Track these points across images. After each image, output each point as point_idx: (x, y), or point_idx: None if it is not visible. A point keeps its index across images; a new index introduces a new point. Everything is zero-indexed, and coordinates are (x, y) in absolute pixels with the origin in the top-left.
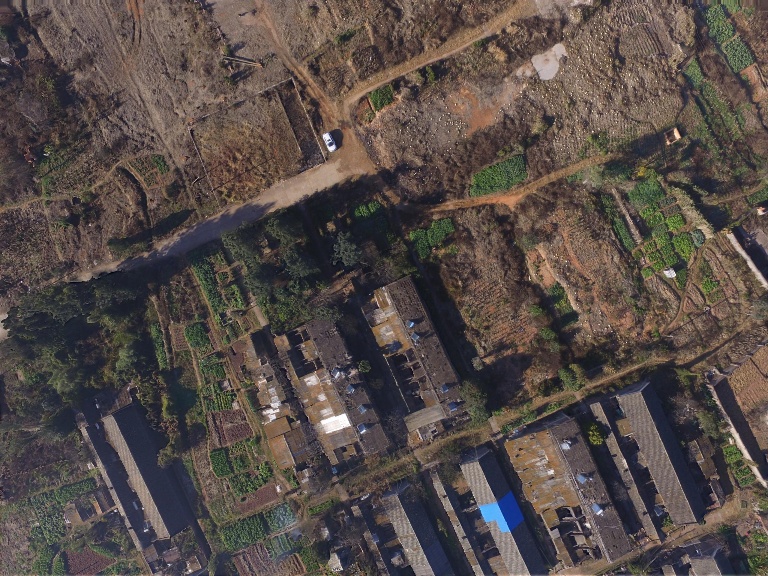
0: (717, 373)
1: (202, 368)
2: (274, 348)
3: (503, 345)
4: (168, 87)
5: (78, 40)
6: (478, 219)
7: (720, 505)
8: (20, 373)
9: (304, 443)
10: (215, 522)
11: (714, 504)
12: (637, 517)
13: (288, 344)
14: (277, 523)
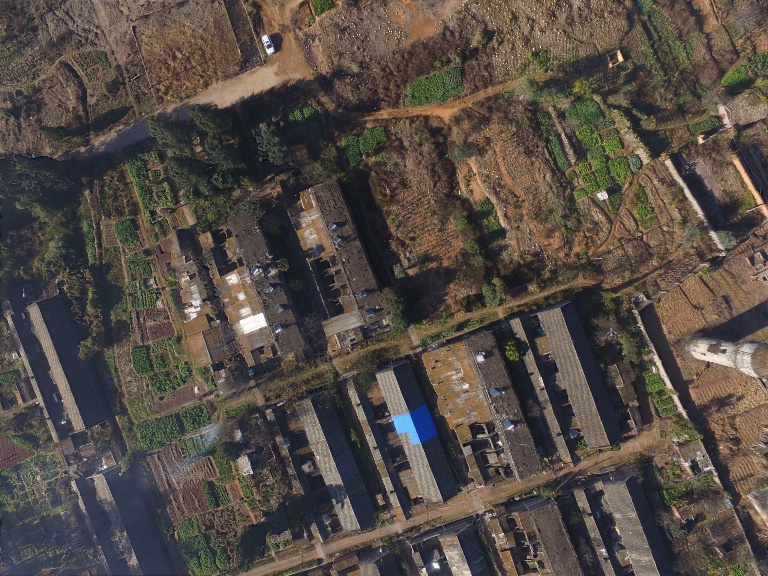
0: (644, 300)
1: (129, 264)
2: (200, 247)
3: (428, 257)
4: None
5: None
6: (411, 129)
7: (637, 432)
8: None
9: (222, 342)
10: (133, 420)
11: (631, 431)
12: (552, 440)
13: (212, 241)
14: (192, 423)
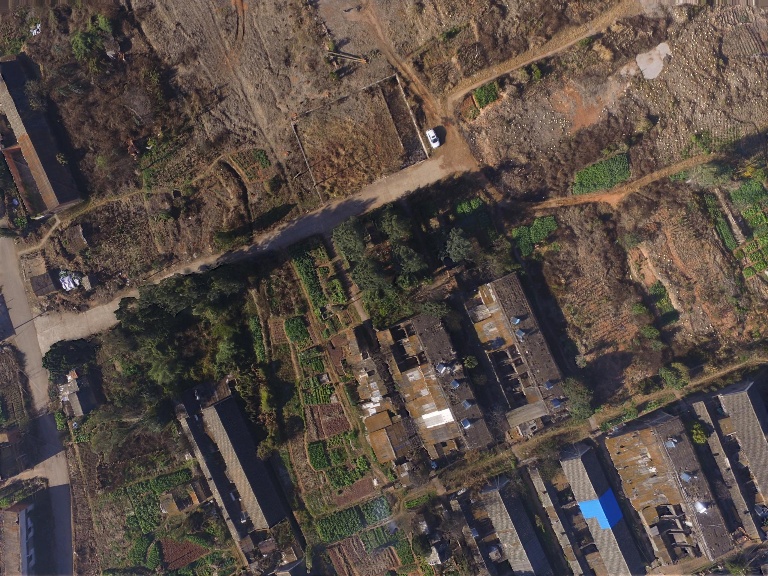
0: None
1: (301, 361)
2: (374, 343)
3: (604, 343)
4: (271, 82)
5: (182, 34)
6: (580, 217)
7: None
8: (117, 364)
9: (405, 437)
10: (311, 514)
11: None
12: (736, 516)
13: (391, 339)
14: (374, 516)
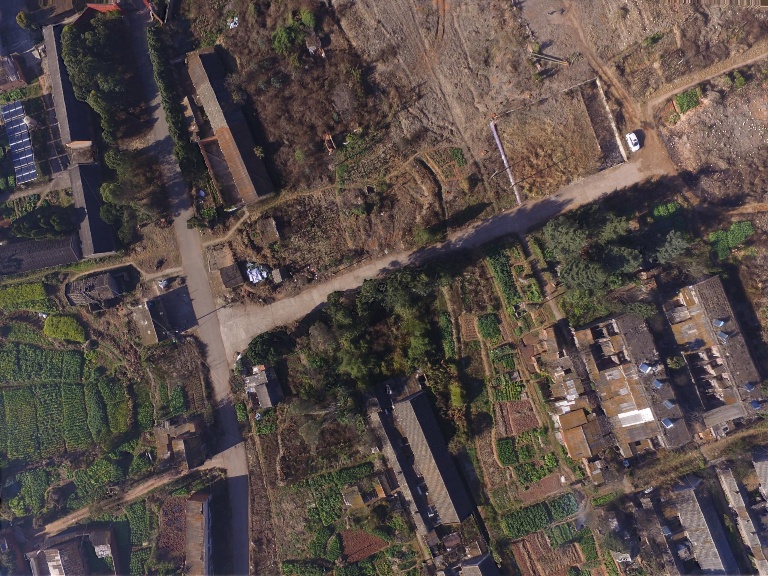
0: None
1: (493, 358)
2: (568, 341)
3: None
4: (471, 82)
5: (382, 32)
6: None
7: None
8: (303, 357)
9: (599, 435)
10: (496, 509)
11: None
12: None
13: (591, 338)
14: (562, 512)
